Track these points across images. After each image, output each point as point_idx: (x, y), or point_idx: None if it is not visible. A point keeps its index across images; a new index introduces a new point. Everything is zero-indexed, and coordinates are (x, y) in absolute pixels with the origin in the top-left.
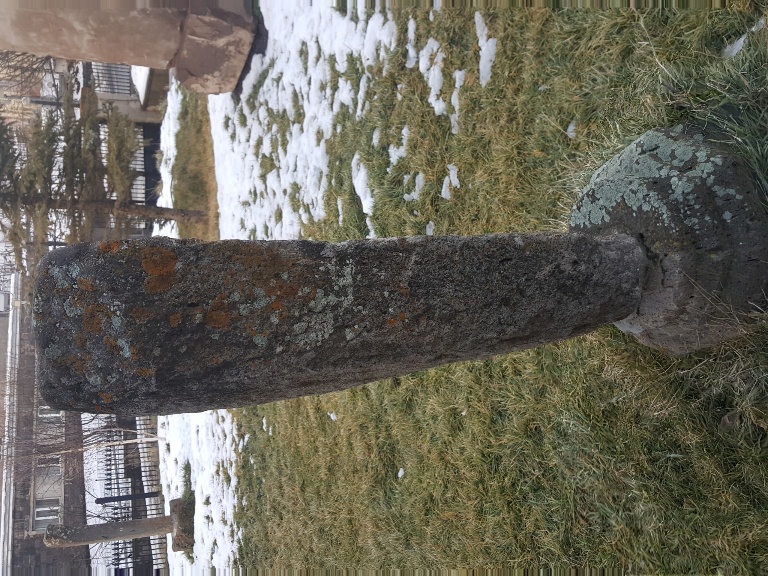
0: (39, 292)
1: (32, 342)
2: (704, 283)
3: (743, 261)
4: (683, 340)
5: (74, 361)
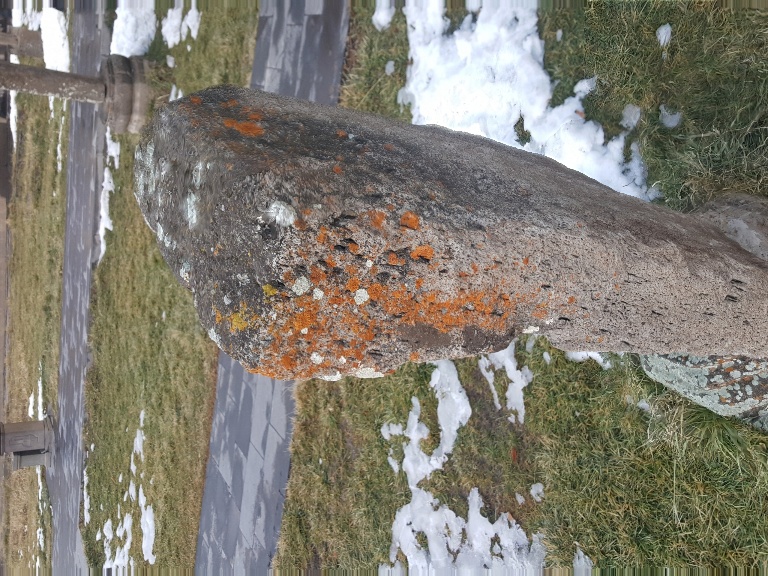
0: None
1: (140, 131)
2: None
3: None
4: (763, 209)
5: None
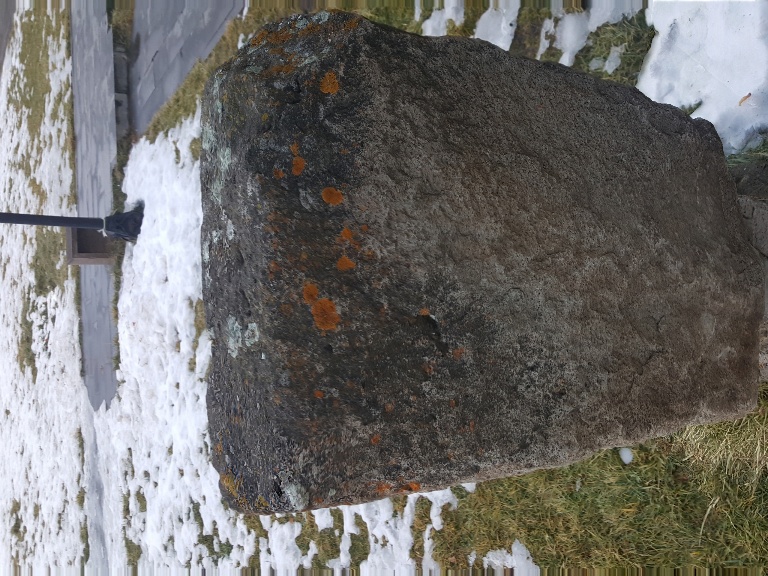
0: (218, 69)
1: (228, 87)
2: (767, 196)
3: (762, 171)
4: None
5: (280, 71)
